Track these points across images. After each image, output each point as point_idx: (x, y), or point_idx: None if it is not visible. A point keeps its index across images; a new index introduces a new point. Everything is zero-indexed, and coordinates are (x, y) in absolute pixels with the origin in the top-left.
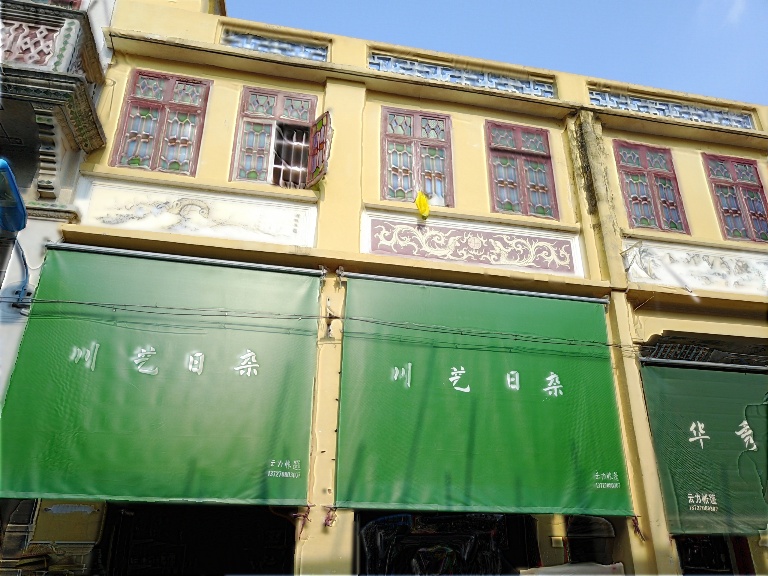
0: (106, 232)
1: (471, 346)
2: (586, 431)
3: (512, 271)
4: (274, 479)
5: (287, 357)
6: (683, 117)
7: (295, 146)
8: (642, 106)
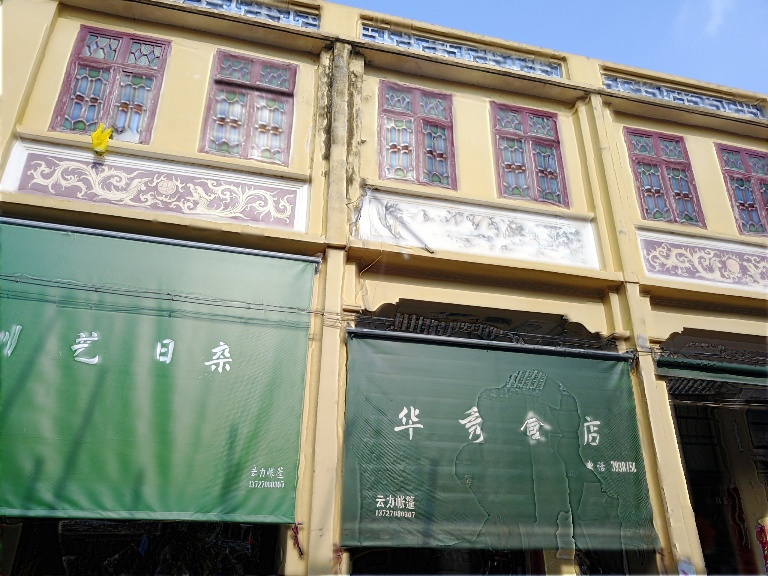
0: None
1: (111, 307)
2: (251, 416)
3: (194, 219)
4: None
5: None
6: (477, 62)
7: None
8: (428, 47)
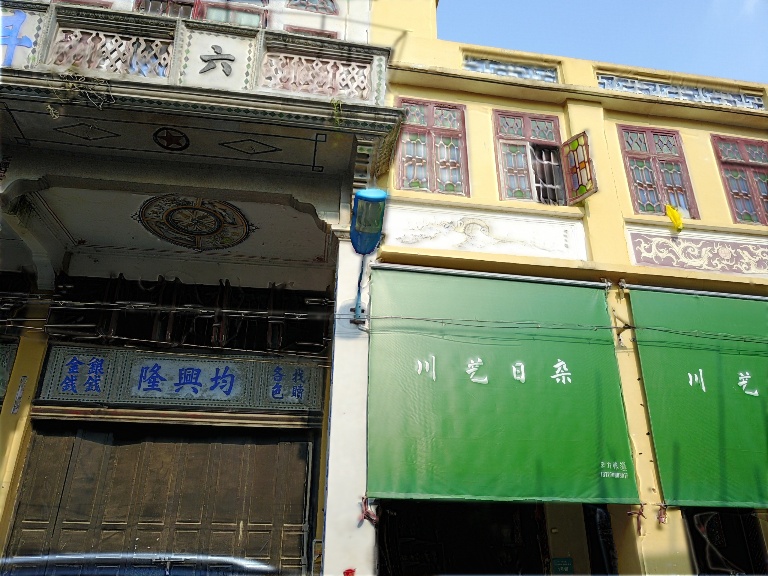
0: (420, 252)
1: (752, 352)
2: None
3: None
4: (607, 479)
5: (593, 365)
6: None
7: (546, 165)
8: None
